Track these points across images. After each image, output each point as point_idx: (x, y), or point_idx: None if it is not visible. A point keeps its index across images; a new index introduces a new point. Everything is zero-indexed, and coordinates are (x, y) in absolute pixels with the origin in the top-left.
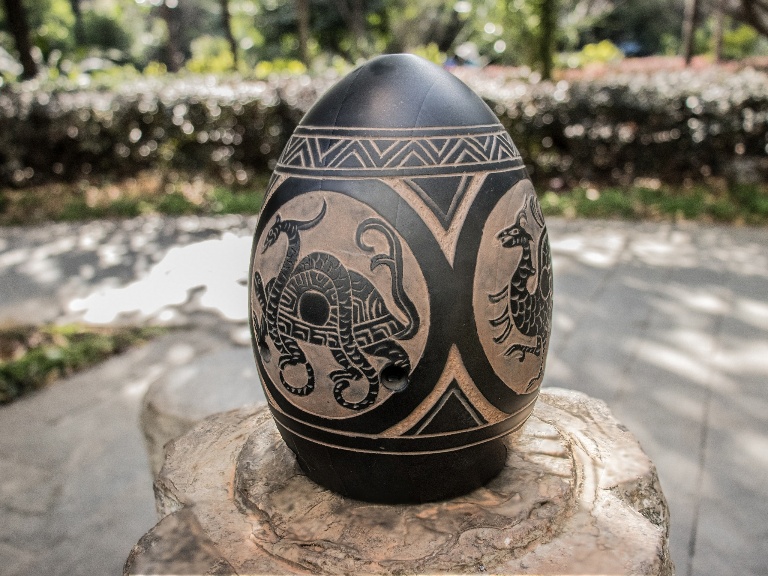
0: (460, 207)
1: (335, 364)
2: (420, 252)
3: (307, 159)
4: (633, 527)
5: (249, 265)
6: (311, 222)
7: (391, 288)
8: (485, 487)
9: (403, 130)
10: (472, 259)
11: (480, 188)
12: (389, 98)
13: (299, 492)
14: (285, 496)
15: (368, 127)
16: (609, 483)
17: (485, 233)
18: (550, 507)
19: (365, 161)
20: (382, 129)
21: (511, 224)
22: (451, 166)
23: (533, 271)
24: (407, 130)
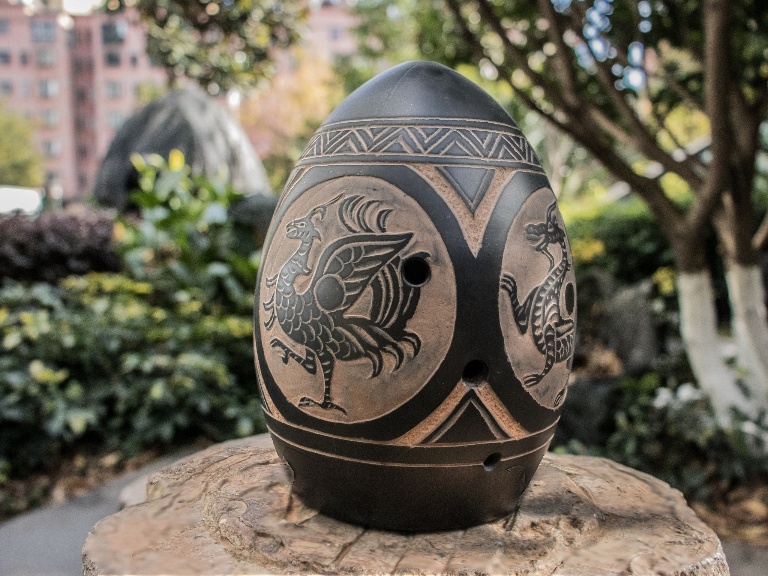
0: None
1: None
2: None
3: None
4: None
5: None
6: None
7: None
8: (317, 514)
9: None
10: None
11: None
12: None
13: None
14: None
15: None
16: None
17: (283, 221)
18: (278, 550)
19: None
20: None
21: None
22: None
23: (308, 271)
24: None
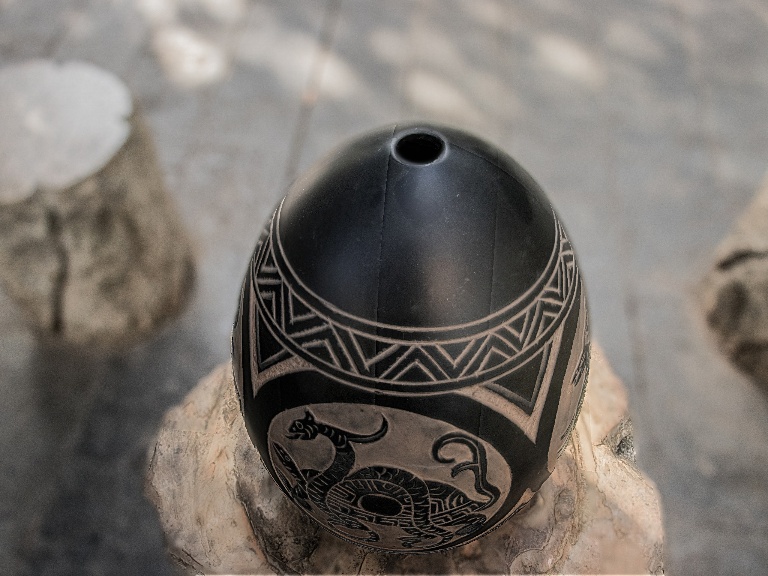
0: (542, 383)
1: (406, 534)
2: (505, 447)
3: (343, 360)
4: (636, 497)
5: (249, 411)
6: (368, 438)
7: (474, 484)
8: None
9: (477, 324)
10: (552, 423)
11: (559, 348)
12: (449, 276)
13: (336, 547)
14: (325, 556)
15: (430, 327)
16: (600, 436)
17: (562, 389)
18: (566, 495)
19: (434, 374)
20: (450, 328)
21: (580, 354)
22: (533, 345)
23: None
24: (482, 322)
